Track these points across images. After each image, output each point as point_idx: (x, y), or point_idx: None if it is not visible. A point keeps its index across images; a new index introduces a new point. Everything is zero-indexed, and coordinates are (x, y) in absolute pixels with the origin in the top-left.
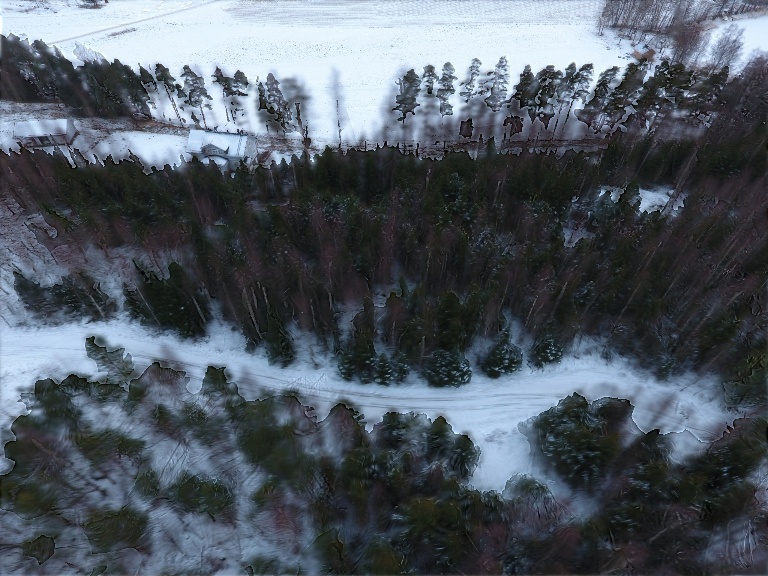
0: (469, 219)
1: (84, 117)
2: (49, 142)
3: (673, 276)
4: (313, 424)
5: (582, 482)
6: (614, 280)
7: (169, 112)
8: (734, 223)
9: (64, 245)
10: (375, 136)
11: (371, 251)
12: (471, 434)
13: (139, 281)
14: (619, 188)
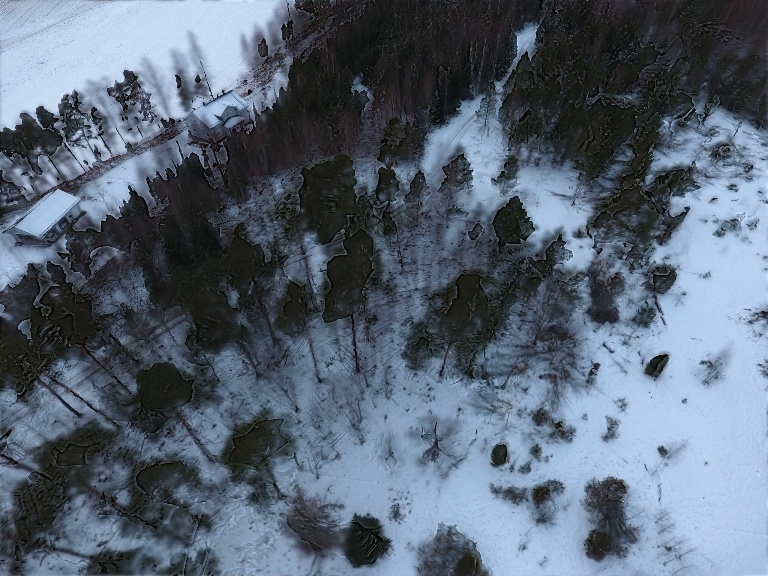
0: None
1: None
2: (65, 224)
3: None
4: None
5: (572, 33)
6: (492, 1)
7: None
8: None
9: None
10: None
11: None
12: None
13: None
14: None
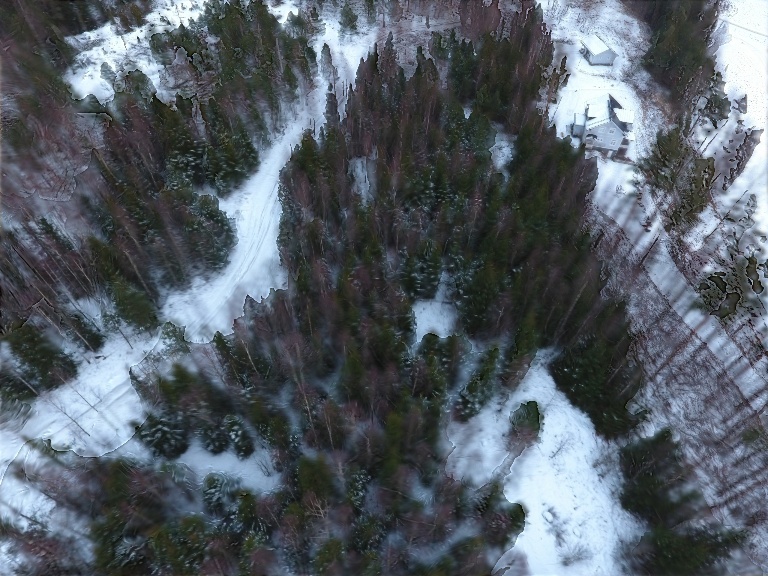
0: None
1: (645, 68)
2: None
3: (316, 340)
4: (254, 110)
5: None
6: None
7: None
8: (411, 499)
9: None
10: (765, 281)
11: (388, 136)
12: (246, 206)
13: None
14: (612, 489)
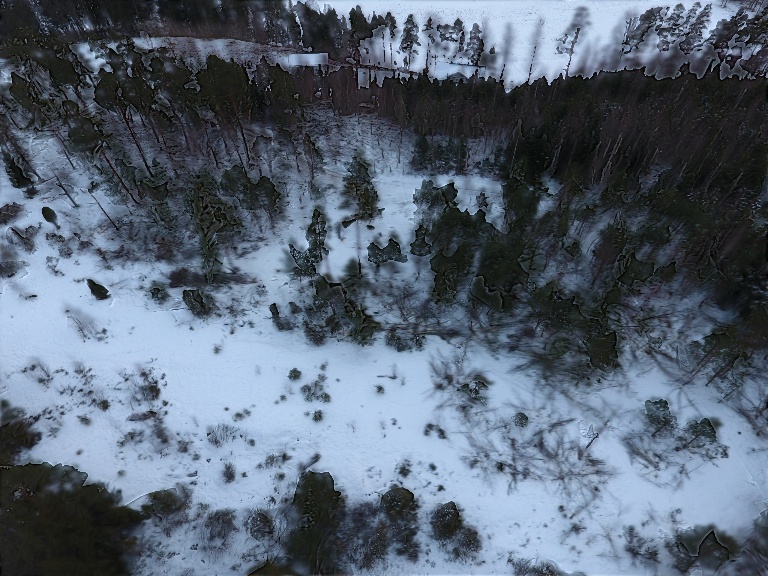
0: (720, 118)
1: None
2: None
3: None
4: None
5: None
6: None
7: (365, 60)
8: None
9: (395, 132)
10: None
11: None
12: None
13: (521, 136)
14: None
